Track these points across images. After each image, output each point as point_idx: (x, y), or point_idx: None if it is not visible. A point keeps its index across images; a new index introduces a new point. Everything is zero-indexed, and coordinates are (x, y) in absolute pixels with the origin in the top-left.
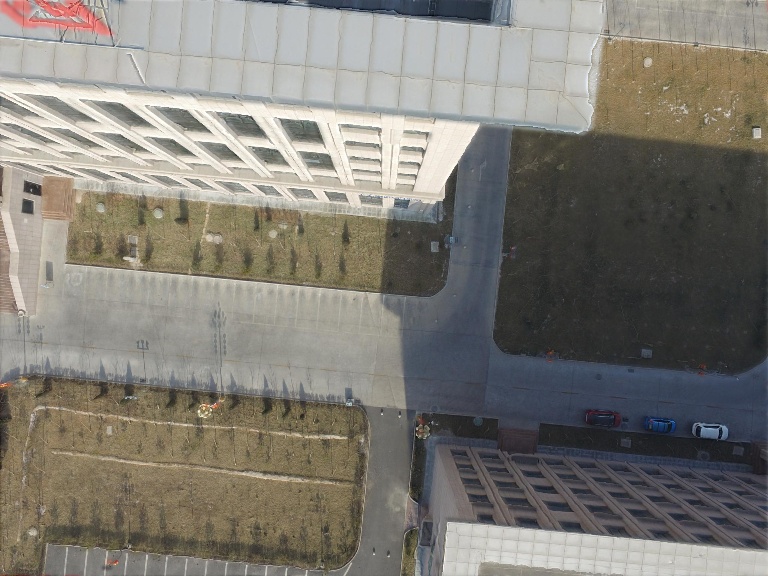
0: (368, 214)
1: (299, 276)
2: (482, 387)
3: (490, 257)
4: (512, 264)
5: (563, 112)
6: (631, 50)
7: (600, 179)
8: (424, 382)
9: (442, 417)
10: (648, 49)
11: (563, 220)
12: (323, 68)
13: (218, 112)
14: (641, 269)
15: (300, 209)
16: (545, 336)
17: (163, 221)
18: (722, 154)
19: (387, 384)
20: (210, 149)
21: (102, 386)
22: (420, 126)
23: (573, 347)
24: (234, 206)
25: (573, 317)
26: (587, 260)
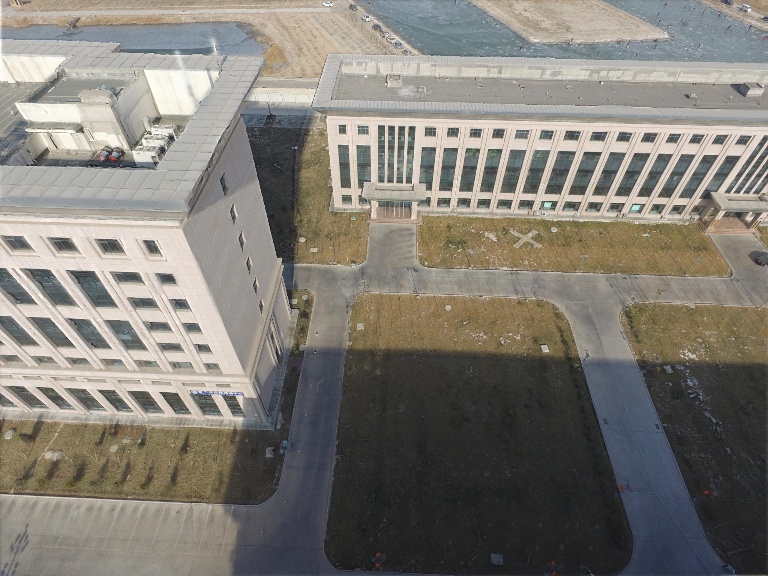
0: (210, 425)
1: (126, 489)
2: None
3: (324, 460)
4: (345, 466)
5: (173, 197)
6: (435, 301)
7: (423, 388)
8: None
9: None
10: (447, 300)
11: (393, 423)
12: (43, 186)
13: (33, 274)
14: (474, 465)
15: (147, 424)
16: (381, 544)
17: (10, 442)
18: (522, 365)
19: None
20: (45, 331)
21: None
22: (162, 267)
23: (414, 556)
24: (86, 425)
25: (411, 520)
26: (419, 458)
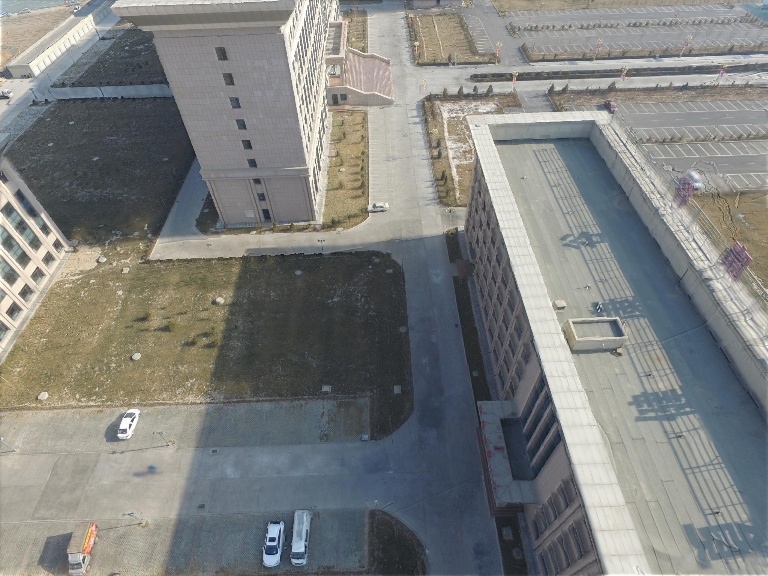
0: None
1: None
2: (394, 4)
3: None
4: None
5: None
6: None
7: None
8: (395, 10)
9: (405, 7)
10: None
11: None
12: None
13: None
14: None
15: None
16: None
17: None
18: None
19: (397, 14)
20: None
21: (413, 49)
22: None
23: None
24: None
25: None
26: None
